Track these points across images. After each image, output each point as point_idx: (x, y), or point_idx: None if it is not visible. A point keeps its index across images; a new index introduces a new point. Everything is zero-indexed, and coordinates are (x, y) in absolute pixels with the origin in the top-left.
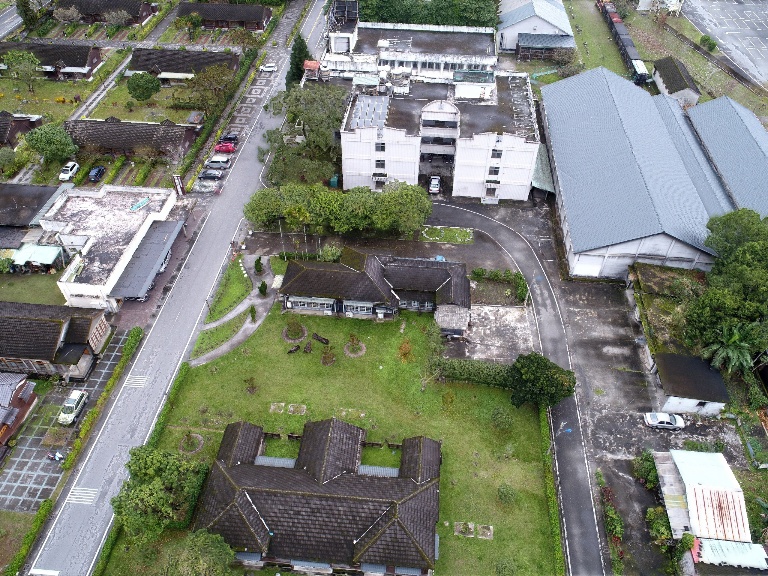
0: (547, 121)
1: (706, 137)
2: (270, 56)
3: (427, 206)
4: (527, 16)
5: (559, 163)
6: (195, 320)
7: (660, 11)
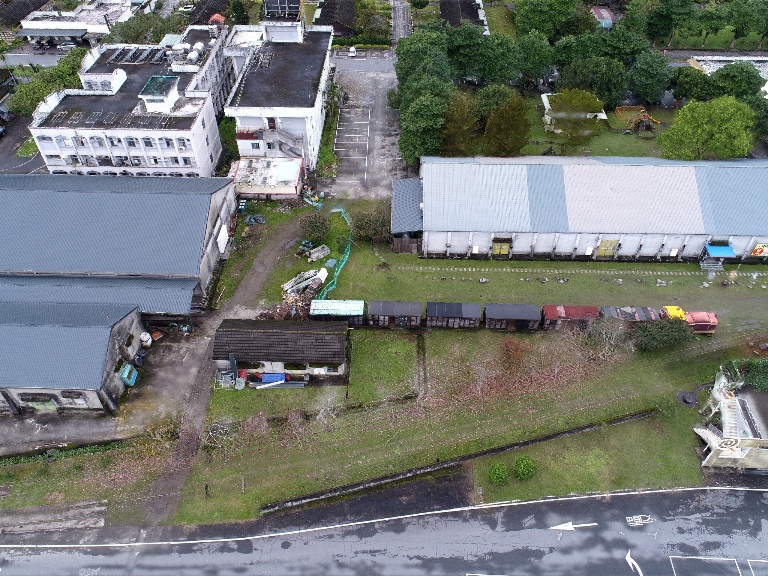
0: (145, 176)
1: (47, 304)
2: (386, 52)
3: (22, 105)
4: (426, 160)
5: (51, 175)
6: (7, 64)
7: (656, 400)
